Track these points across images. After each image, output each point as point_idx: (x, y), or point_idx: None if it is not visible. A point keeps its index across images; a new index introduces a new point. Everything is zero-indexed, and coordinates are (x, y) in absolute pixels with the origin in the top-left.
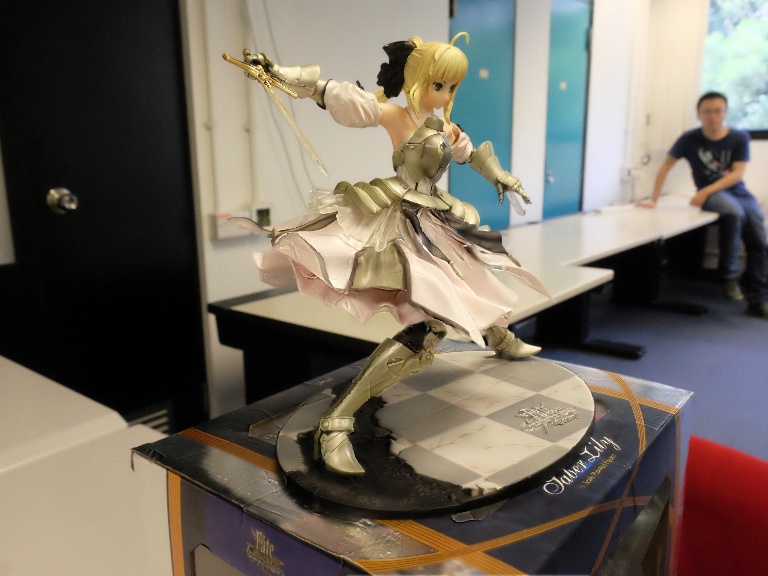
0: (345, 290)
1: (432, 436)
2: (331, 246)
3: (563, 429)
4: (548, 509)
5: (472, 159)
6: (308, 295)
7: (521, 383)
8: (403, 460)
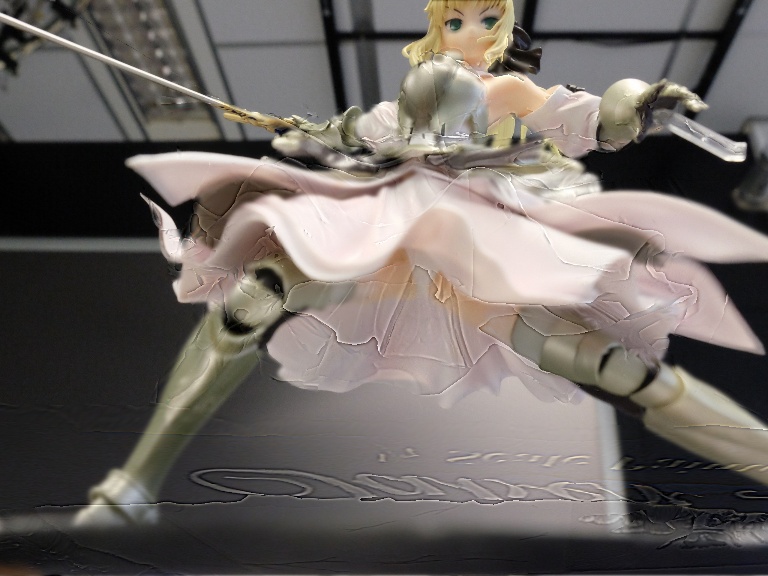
0: None
1: None
2: None
3: None
4: None
5: (599, 119)
6: None
7: None
8: (150, 568)
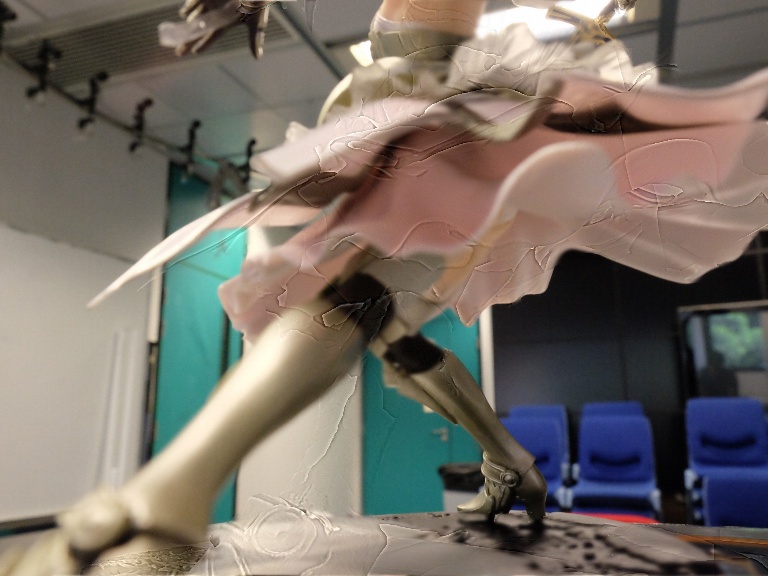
0: None
1: None
2: None
3: None
4: None
5: None
6: None
7: None
8: None
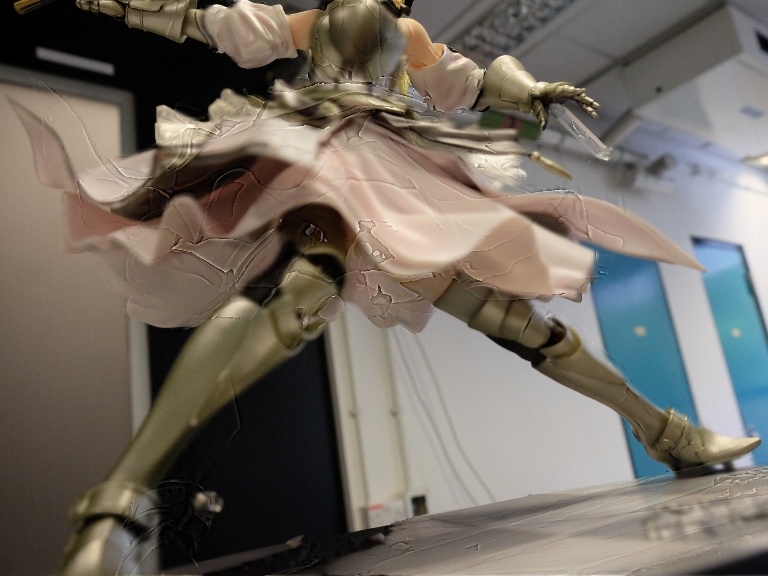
0: (150, 178)
1: (472, 557)
2: (152, 142)
3: None
4: None
5: (481, 88)
6: (100, 229)
7: (724, 472)
8: None
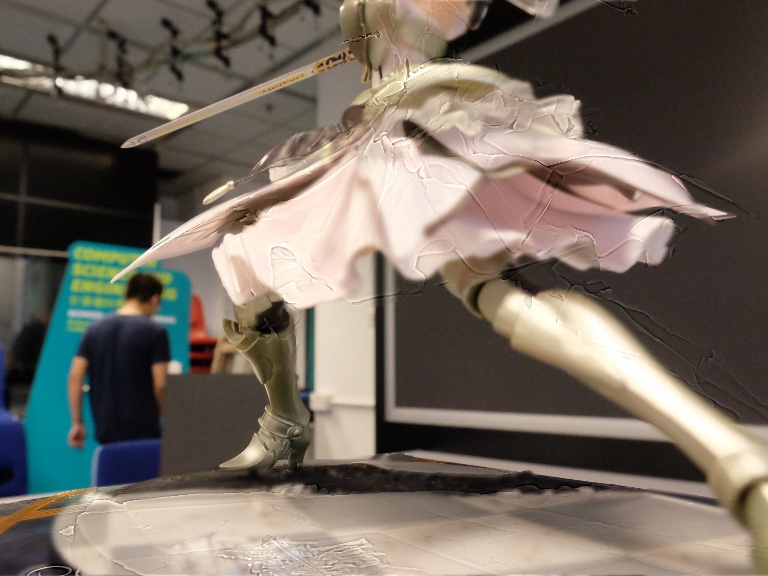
0: None
1: (316, 504)
2: None
3: (225, 570)
4: (1, 562)
5: None
6: None
7: (615, 575)
8: None
